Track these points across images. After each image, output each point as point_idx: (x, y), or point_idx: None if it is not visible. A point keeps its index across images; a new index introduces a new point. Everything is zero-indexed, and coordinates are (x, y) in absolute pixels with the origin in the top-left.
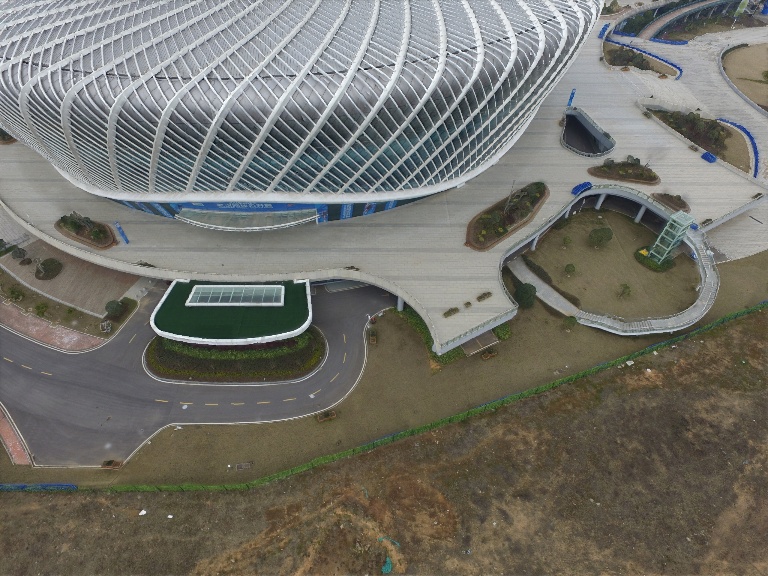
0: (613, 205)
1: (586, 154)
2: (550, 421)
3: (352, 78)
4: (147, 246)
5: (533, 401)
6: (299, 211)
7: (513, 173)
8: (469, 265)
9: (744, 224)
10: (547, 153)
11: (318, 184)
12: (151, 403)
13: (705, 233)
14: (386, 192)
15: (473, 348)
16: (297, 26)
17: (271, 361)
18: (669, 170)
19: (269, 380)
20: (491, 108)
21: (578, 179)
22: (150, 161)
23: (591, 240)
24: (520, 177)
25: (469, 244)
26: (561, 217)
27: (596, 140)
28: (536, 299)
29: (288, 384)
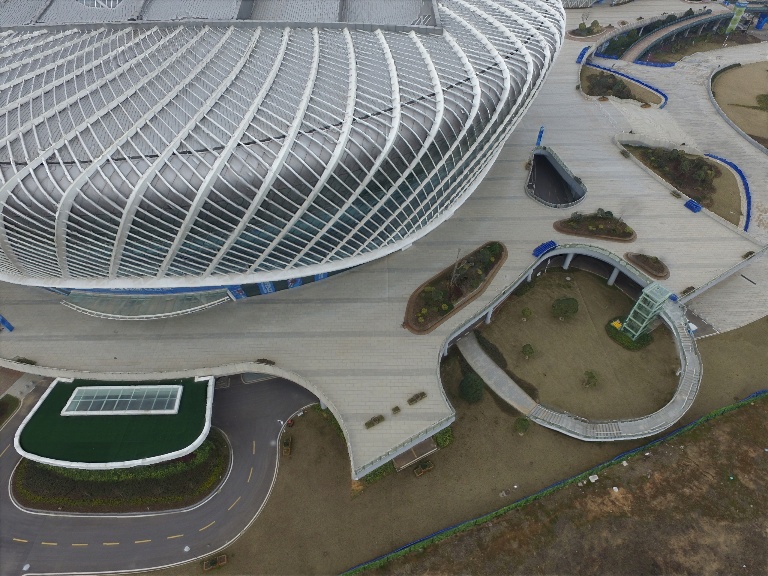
0: (584, 263)
1: (552, 205)
2: (489, 567)
3: (228, 157)
4: (33, 334)
5: (471, 536)
6: (206, 292)
7: (468, 230)
8: (404, 354)
9: (734, 285)
10: (509, 204)
11: (218, 267)
12: (7, 544)
13: (685, 307)
14: (309, 266)
15: (405, 459)
16: (173, 89)
17: (160, 483)
18: (647, 223)
19: (154, 509)
20: (421, 173)
21: (541, 236)
22: (4, 252)
23: (554, 311)
24: (475, 235)
25: (407, 325)
26: (523, 280)
27: (567, 184)
28: (486, 389)
29: (177, 514)
